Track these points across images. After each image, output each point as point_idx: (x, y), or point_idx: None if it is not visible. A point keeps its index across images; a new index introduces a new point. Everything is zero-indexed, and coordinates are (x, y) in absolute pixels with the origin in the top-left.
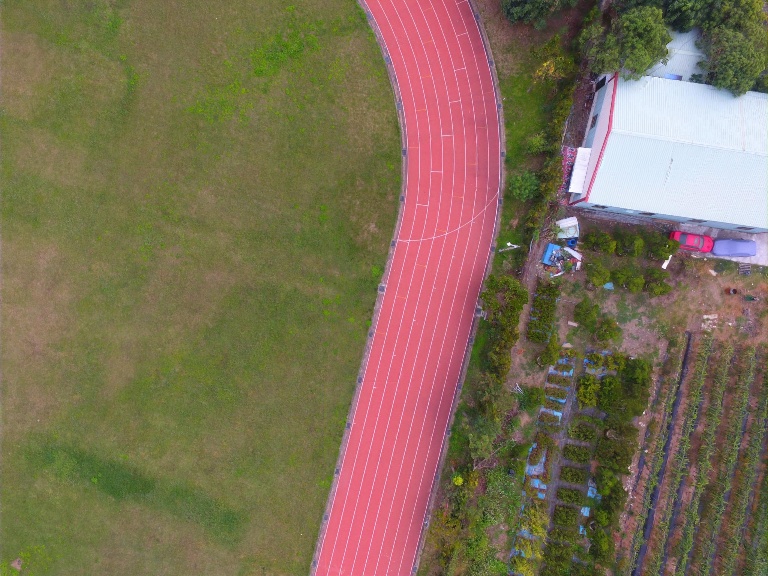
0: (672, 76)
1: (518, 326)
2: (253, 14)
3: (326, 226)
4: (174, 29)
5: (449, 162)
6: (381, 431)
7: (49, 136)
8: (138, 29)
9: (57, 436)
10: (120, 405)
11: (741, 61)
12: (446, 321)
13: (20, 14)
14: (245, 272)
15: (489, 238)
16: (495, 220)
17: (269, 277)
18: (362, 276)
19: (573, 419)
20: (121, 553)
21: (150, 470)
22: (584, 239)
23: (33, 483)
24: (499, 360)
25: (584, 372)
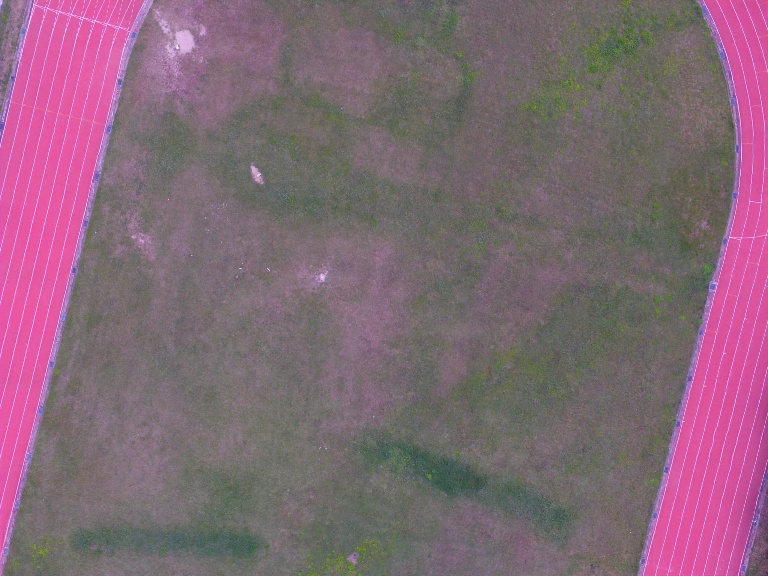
0: None
1: None
2: (588, 10)
3: (658, 223)
4: (510, 26)
5: None
6: (711, 430)
7: (385, 134)
8: (474, 26)
9: (392, 432)
10: (453, 402)
11: None
12: None
13: (358, 12)
14: (577, 270)
15: None
16: None
17: (601, 275)
18: (694, 274)
19: None
20: (453, 548)
21: (482, 467)
22: None
23: (368, 478)
24: None
25: None
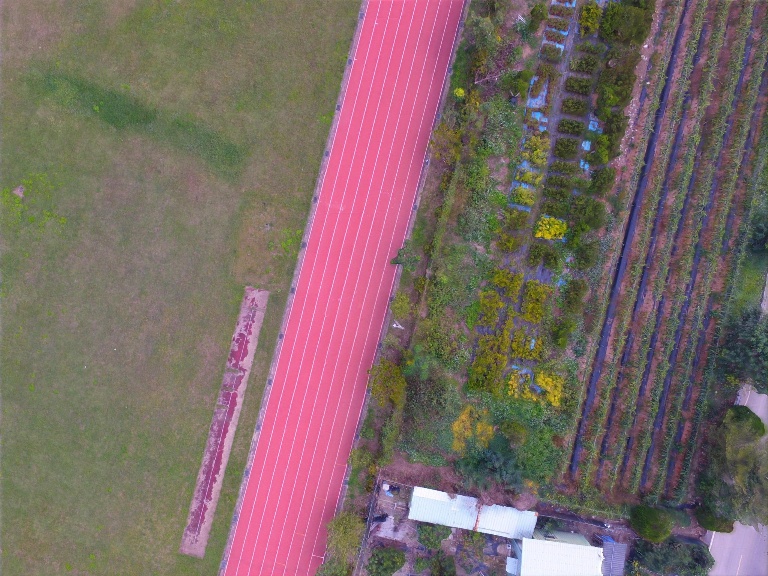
0: None
1: None
2: None
3: None
4: None
5: None
6: (382, 68)
7: None
8: None
9: (59, 63)
10: (121, 35)
11: None
12: None
13: None
14: None
15: None
16: None
17: None
18: None
19: (575, 49)
20: (123, 183)
21: (151, 101)
22: None
23: (35, 110)
24: None
25: None
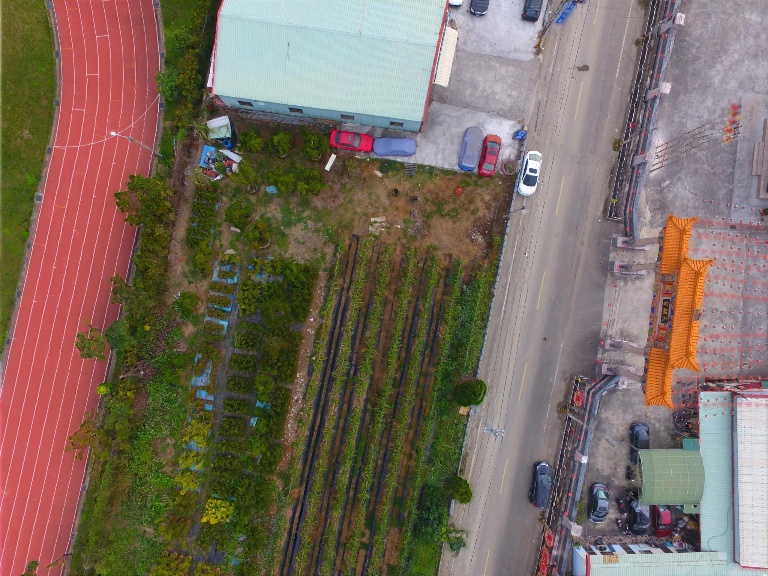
0: None
1: (179, 233)
2: None
3: None
4: None
5: (105, 64)
6: (43, 346)
7: None
8: None
9: None
10: None
11: None
12: (108, 231)
13: None
14: None
15: (151, 143)
16: (156, 124)
17: None
18: (16, 185)
19: None
20: None
21: None
22: None
23: None
24: None
25: (249, 279)
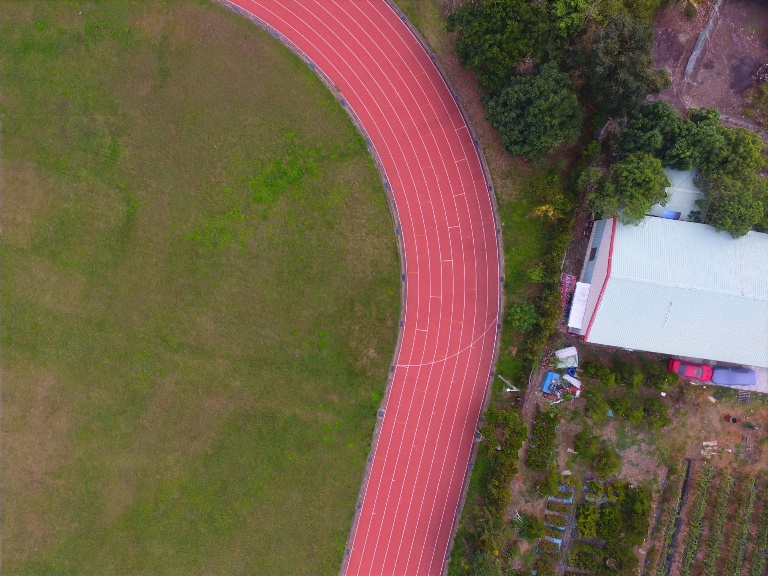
0: (671, 213)
1: None
2: (252, 141)
3: (325, 352)
4: (173, 157)
5: (448, 287)
6: (380, 557)
7: (48, 264)
8: (137, 157)
9: (55, 565)
10: (118, 533)
11: (739, 211)
12: (445, 446)
13: (19, 143)
14: (244, 398)
15: (488, 363)
16: (494, 345)
17: (268, 403)
18: (361, 402)
19: (573, 547)
20: None
21: None
22: (583, 367)
23: None
24: (498, 494)
25: (584, 499)
